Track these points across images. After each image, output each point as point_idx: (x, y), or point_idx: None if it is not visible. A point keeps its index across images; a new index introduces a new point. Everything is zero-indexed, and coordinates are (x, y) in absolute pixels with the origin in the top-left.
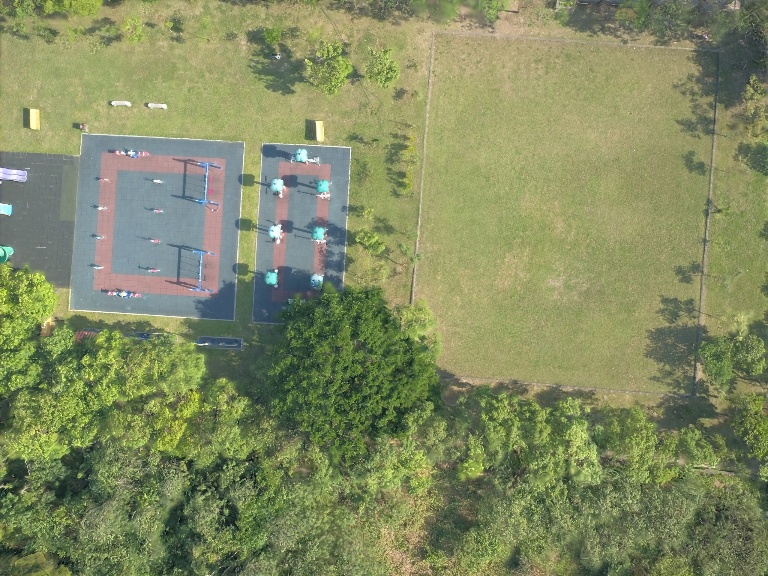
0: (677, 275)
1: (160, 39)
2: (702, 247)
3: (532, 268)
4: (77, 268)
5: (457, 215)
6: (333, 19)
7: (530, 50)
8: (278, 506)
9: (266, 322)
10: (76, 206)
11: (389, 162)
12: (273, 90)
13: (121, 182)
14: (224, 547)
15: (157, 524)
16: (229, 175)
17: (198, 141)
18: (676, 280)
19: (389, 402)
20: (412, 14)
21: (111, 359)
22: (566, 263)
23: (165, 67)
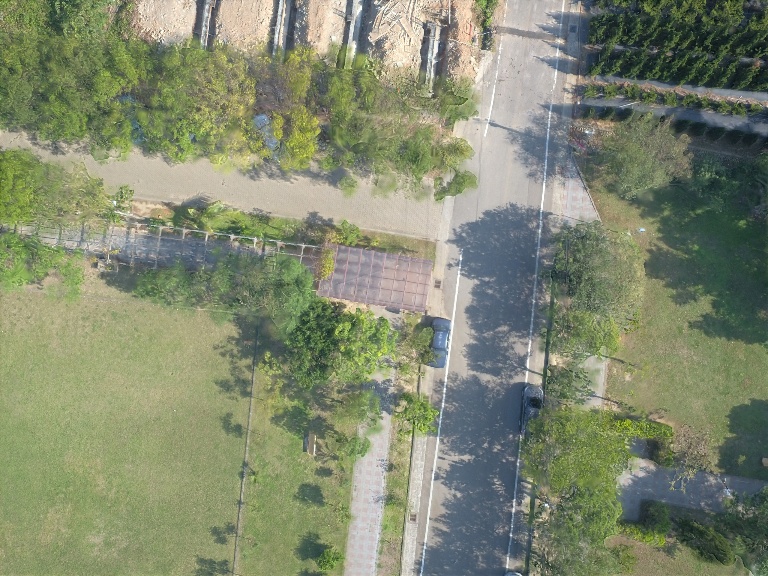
0: (212, 536)
1: None
2: (237, 509)
3: (74, 524)
4: None
5: (4, 469)
6: None
7: (78, 307)
8: None
9: None
10: None
11: None
12: None
13: None
14: None
15: None
16: None
17: None
18: (211, 541)
19: None
20: None
21: None
22: (106, 520)
23: None
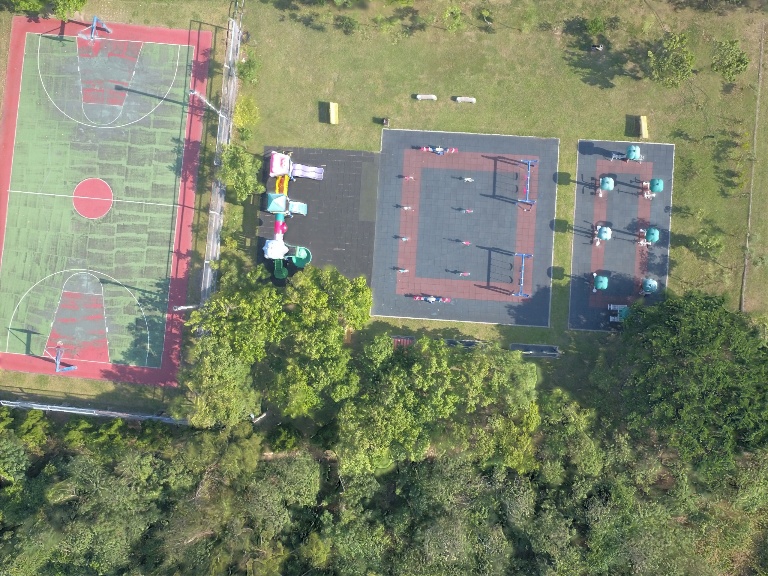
0: None
1: (467, 29)
2: None
3: None
4: (378, 271)
5: None
6: (655, 9)
7: None
8: (632, 525)
9: (584, 329)
10: (377, 205)
11: (716, 160)
12: (590, 83)
13: (426, 180)
14: (570, 569)
15: (505, 545)
16: (543, 173)
17: (509, 137)
18: None
19: (761, 415)
20: (741, 4)
21: (446, 368)
22: None
23: (473, 59)
